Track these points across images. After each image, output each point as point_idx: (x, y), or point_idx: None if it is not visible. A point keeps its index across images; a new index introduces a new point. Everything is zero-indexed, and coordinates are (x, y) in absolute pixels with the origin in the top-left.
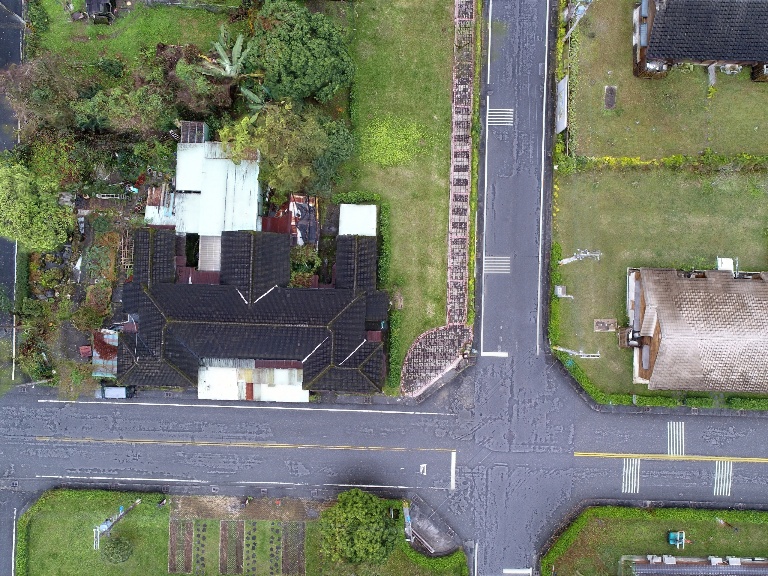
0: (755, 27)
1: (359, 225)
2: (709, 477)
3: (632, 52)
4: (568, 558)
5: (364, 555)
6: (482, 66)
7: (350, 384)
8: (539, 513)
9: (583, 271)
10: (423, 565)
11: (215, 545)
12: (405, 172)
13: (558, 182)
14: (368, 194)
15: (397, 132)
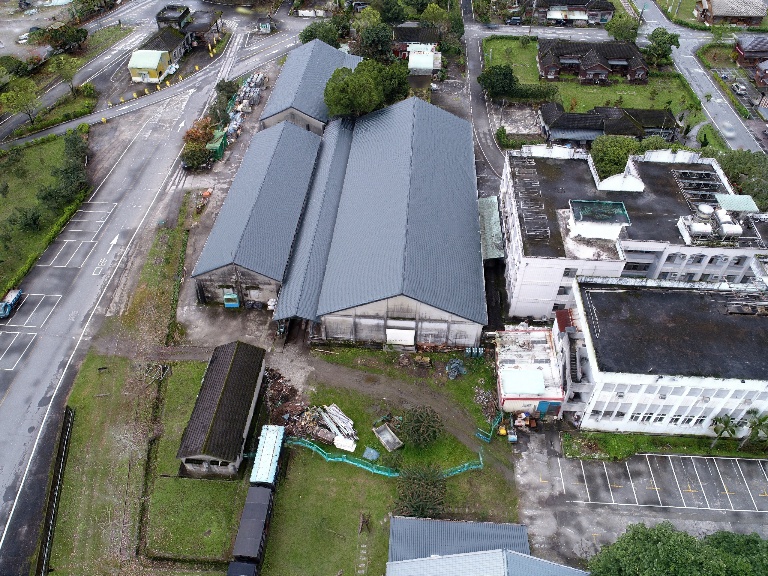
0: None
1: None
2: None
3: None
4: None
5: None
6: None
7: (605, 7)
8: (688, 46)
9: None
10: None
11: None
12: None
13: None
14: None
15: None
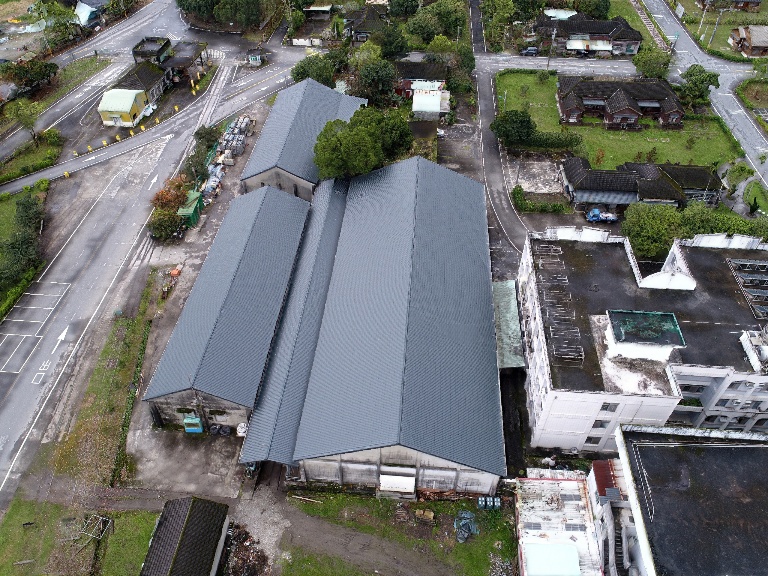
0: None
1: None
2: None
3: None
4: None
5: None
6: None
7: (631, 36)
8: None
9: None
10: None
11: None
12: None
13: None
14: None
15: None
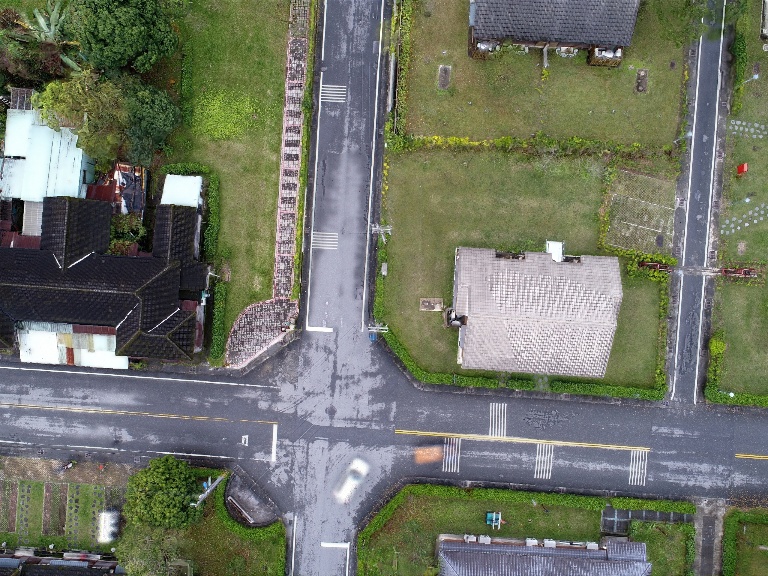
0: (579, 9)
1: (181, 196)
2: (530, 460)
3: (467, 32)
4: (386, 534)
5: (161, 519)
6: (317, 42)
7: (161, 351)
8: (358, 488)
9: (411, 250)
10: (239, 534)
11: (39, 506)
12: (237, 145)
13: (388, 160)
14: (197, 166)
15: (230, 105)
